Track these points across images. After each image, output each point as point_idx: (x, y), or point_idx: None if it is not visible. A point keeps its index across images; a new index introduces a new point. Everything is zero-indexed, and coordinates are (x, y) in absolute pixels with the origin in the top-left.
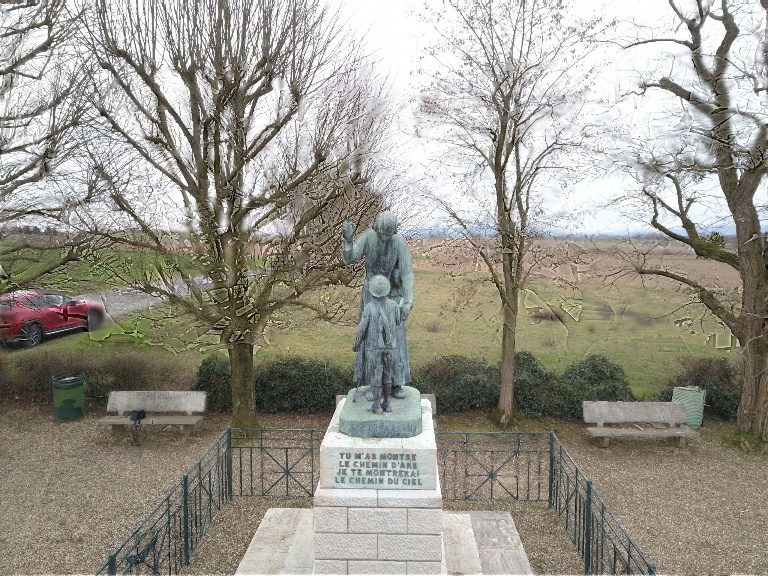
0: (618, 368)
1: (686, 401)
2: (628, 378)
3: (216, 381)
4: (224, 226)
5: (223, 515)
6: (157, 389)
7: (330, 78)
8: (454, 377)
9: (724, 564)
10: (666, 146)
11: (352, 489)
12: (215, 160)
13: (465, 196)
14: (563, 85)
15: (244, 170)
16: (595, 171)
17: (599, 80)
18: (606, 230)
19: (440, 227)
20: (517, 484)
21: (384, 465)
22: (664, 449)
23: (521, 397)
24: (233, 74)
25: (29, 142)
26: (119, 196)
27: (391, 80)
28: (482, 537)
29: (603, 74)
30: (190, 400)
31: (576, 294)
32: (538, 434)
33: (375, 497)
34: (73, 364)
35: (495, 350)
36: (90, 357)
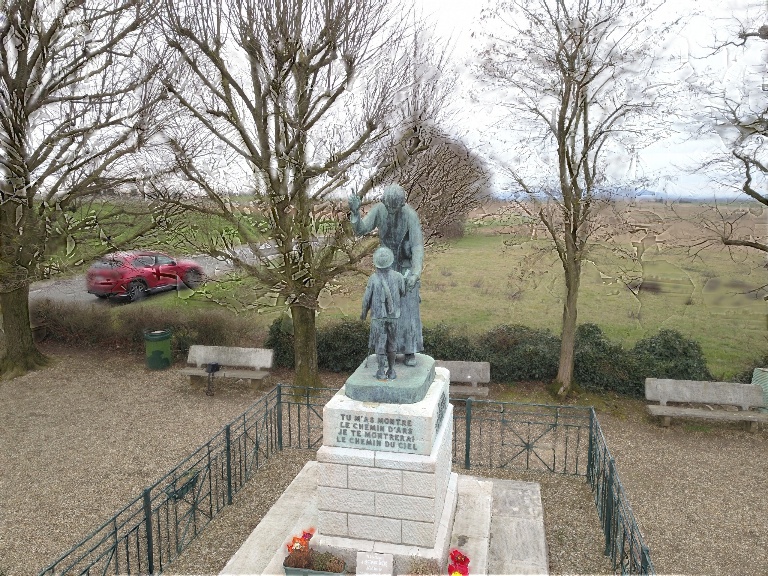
0: (694, 345)
1: (767, 384)
2: (705, 356)
3: (281, 340)
4: (281, 194)
5: (271, 463)
6: (234, 345)
7: (383, 45)
8: (514, 346)
9: (764, 557)
10: (750, 105)
11: (352, 449)
12: (275, 130)
13: (527, 162)
14: (631, 41)
15: (308, 139)
16: (666, 134)
17: (670, 34)
18: (691, 197)
19: (499, 194)
20: (554, 457)
21: (381, 429)
22: (733, 433)
23: (583, 370)
24: (284, 47)
25: (124, 116)
26: (191, 166)
27: (453, 43)
28: (504, 505)
29: (692, 25)
30: (259, 356)
31: (636, 266)
32: (596, 408)
33: (372, 458)
34: (163, 319)
35: (560, 321)
36: (177, 313)
